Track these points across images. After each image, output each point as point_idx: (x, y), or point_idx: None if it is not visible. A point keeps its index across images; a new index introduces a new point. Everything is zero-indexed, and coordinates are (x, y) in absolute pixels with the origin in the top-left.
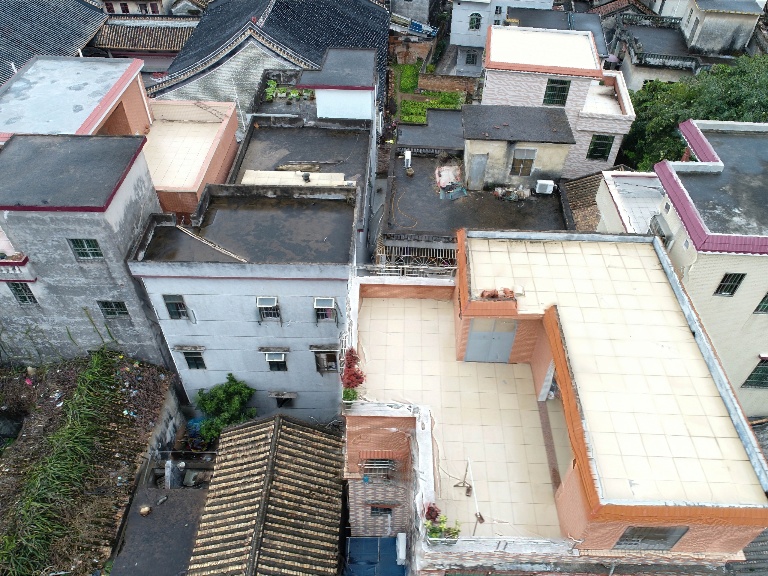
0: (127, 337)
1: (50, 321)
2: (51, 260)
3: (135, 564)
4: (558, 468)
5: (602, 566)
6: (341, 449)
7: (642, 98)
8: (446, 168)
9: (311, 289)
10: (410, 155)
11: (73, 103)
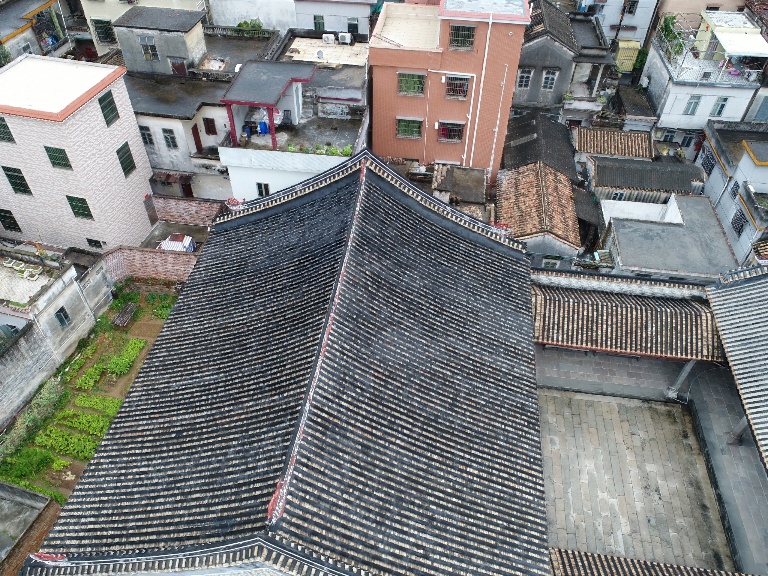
0: None
1: None
2: None
3: None
4: None
5: None
6: None
7: None
8: None
9: None
10: None
11: None
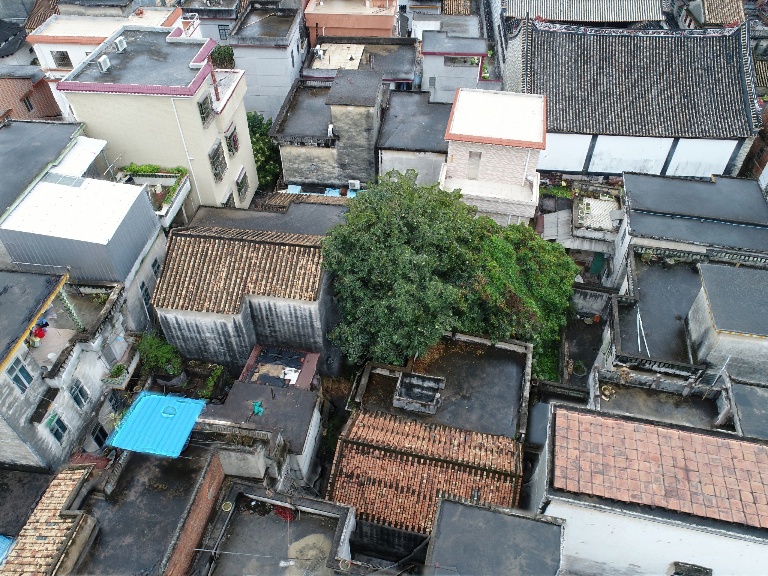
0: None
1: None
2: None
3: None
4: None
5: None
6: None
7: None
8: None
9: None
10: None
11: None
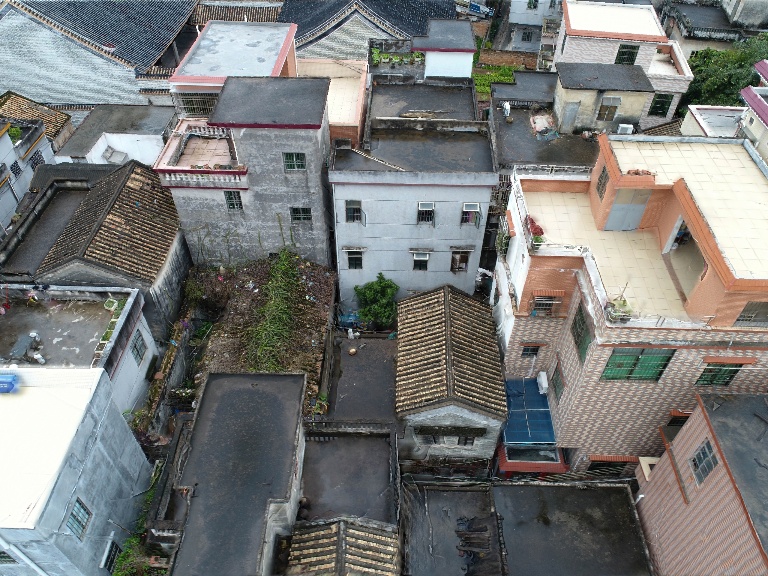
0: (304, 240)
1: (247, 226)
2: (265, 171)
3: (354, 384)
4: (683, 291)
5: (723, 342)
6: (491, 314)
7: (695, 64)
8: (539, 117)
9: (462, 195)
10: (509, 106)
11: (255, 56)
